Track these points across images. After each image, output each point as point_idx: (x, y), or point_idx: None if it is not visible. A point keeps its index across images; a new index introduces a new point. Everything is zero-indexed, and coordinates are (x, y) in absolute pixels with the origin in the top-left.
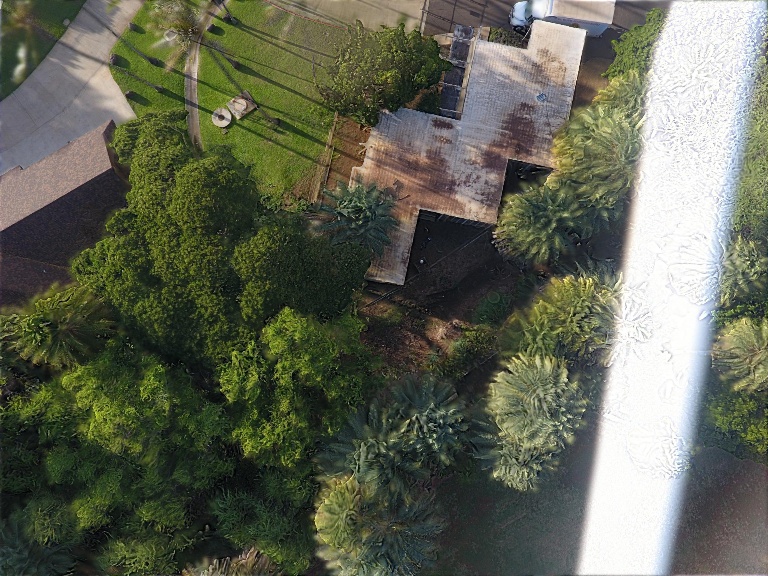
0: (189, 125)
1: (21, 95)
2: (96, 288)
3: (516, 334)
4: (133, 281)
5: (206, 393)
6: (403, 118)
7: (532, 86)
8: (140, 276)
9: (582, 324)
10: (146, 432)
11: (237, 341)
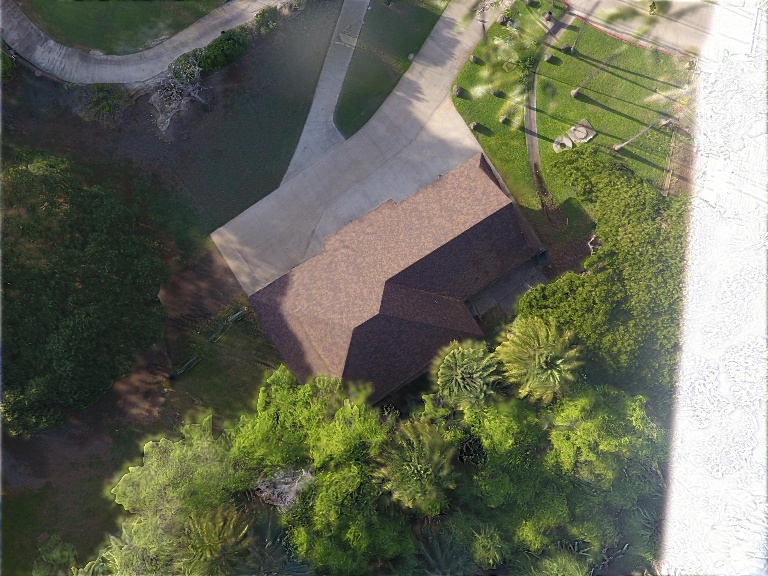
0: (529, 154)
1: (370, 129)
2: (563, 322)
3: None
4: (604, 315)
5: (654, 419)
6: (762, 143)
7: None
8: (612, 310)
9: None
10: (611, 459)
11: (694, 370)
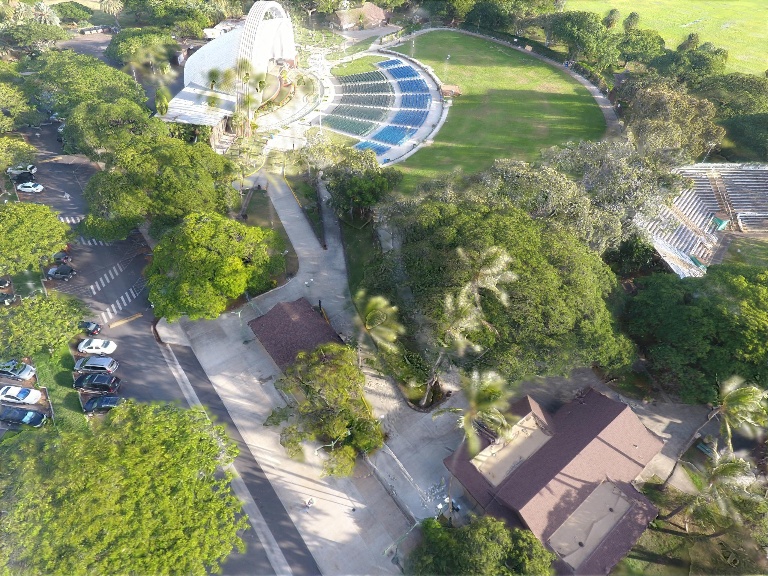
0: None
1: (369, 36)
2: None
3: None
4: None
5: None
6: None
7: (230, 24)
8: None
9: None
10: None
11: None
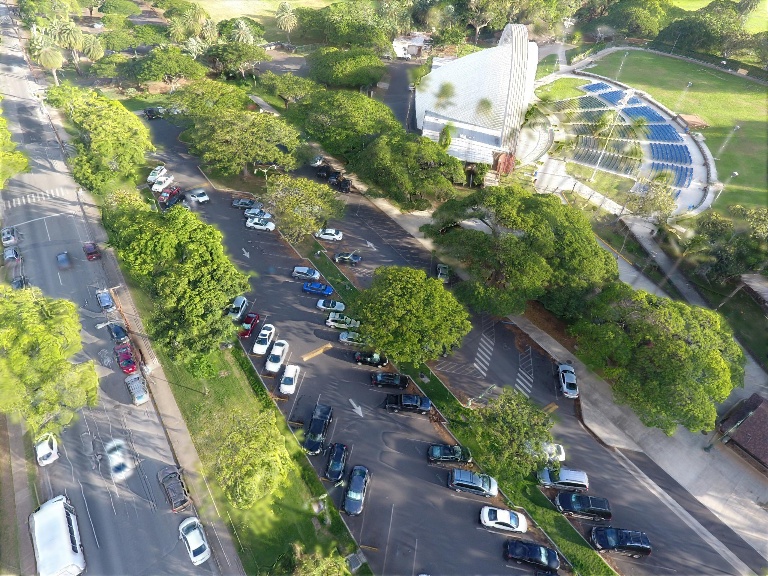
0: None
1: None
2: (499, 3)
3: None
4: None
5: None
6: None
7: None
8: None
9: None
10: None
11: None
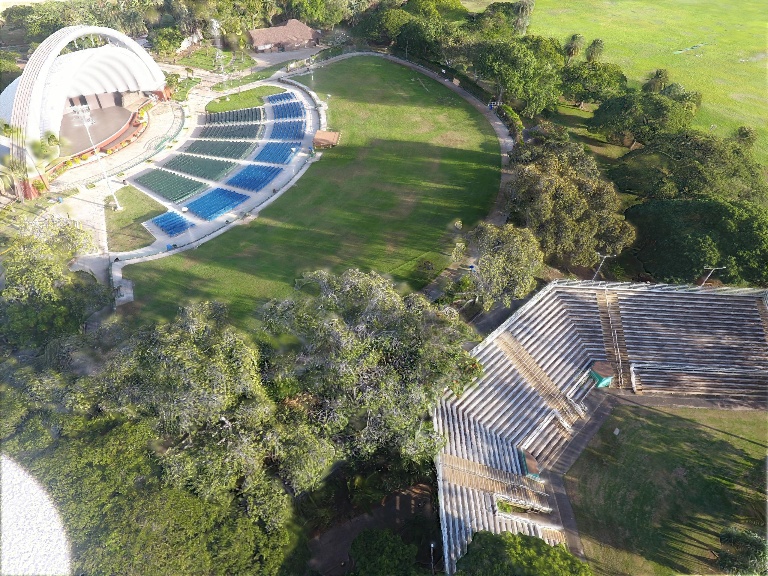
0: None
1: None
2: None
3: (152, 7)
4: None
5: None
6: None
7: None
8: None
9: (136, 0)
10: None
11: None
